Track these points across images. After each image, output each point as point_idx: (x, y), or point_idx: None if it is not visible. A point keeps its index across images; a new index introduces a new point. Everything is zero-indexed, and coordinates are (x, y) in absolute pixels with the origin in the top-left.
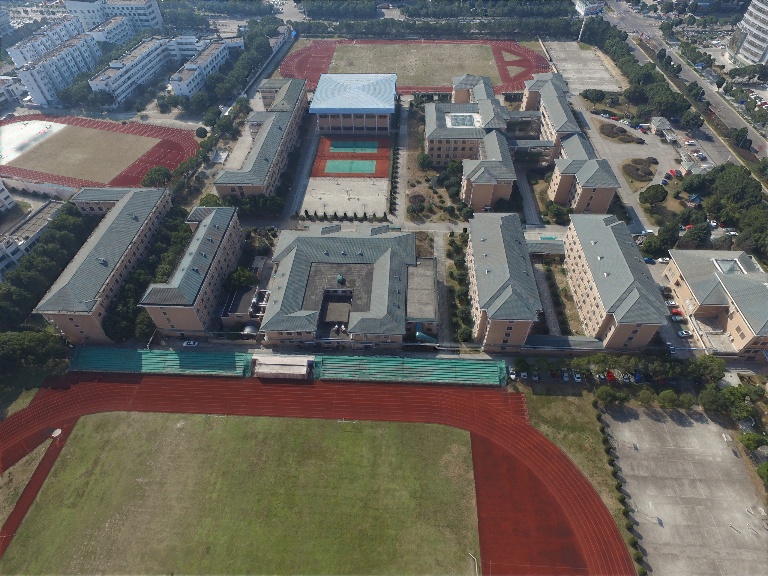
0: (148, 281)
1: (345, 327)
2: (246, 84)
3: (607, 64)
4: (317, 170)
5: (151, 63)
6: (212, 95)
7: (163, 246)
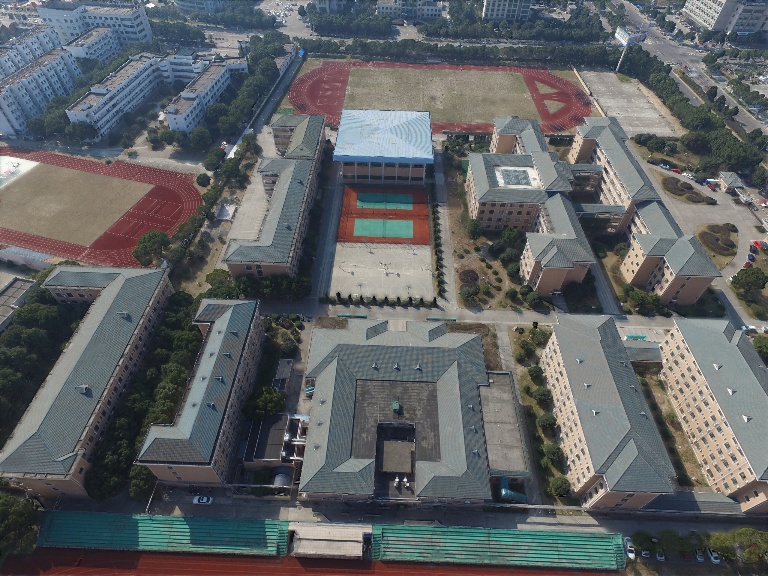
0: (145, 409)
1: (408, 480)
2: (252, 115)
3: (653, 101)
4: (344, 232)
5: (140, 86)
6: (212, 128)
7: (163, 353)
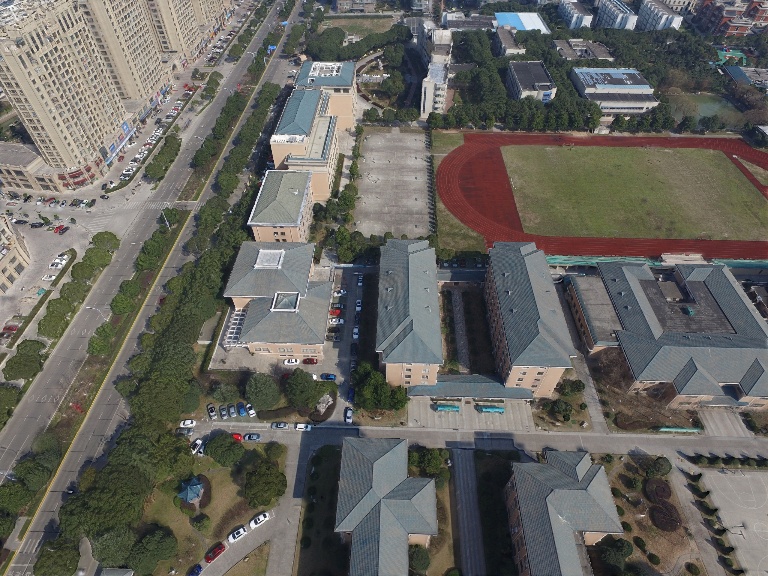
0: None
1: None
2: None
3: None
4: None
5: None
6: None
7: None
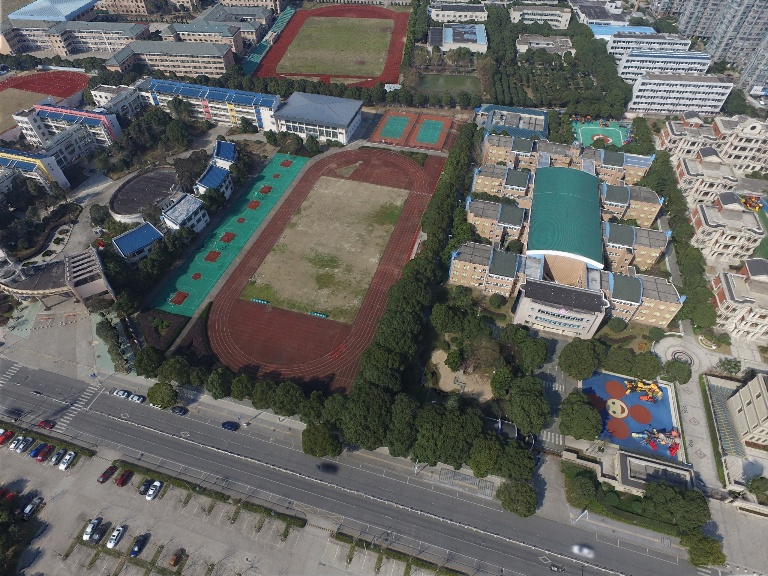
0: None
1: None
2: None
3: None
4: None
5: None
6: None
7: None
